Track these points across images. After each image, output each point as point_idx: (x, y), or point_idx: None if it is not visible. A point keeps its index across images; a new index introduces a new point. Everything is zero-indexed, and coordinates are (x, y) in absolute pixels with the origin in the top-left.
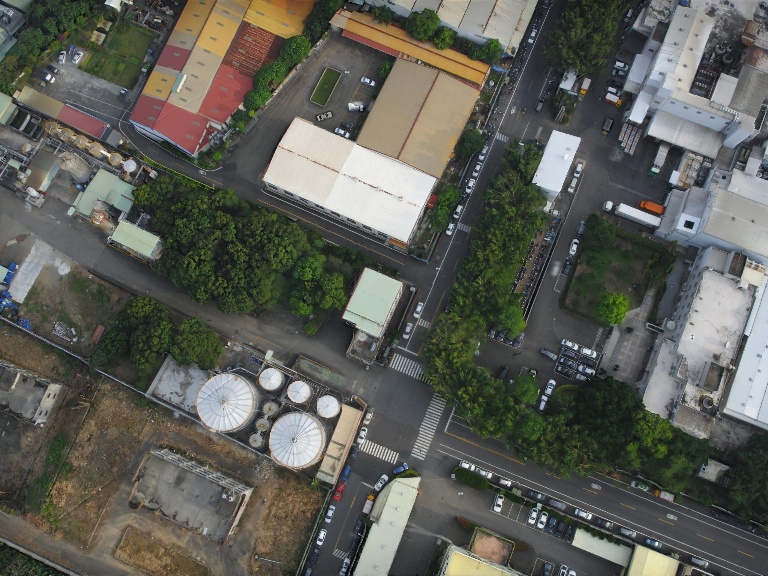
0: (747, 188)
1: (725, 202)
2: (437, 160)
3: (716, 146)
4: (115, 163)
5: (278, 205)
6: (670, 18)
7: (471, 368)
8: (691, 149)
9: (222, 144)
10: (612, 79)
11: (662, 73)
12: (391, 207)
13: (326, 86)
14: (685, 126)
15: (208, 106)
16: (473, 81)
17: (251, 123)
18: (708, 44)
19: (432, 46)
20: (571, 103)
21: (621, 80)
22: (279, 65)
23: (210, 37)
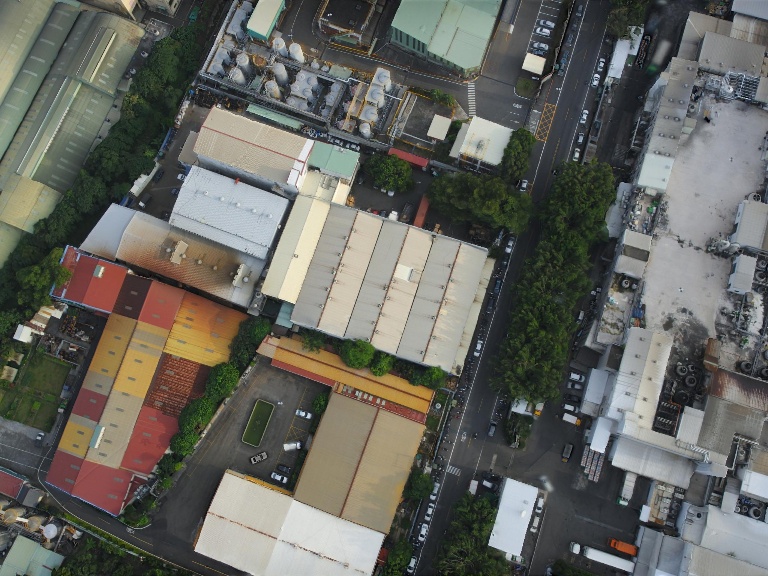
0: (725, 531)
1: (702, 563)
2: (384, 512)
3: (687, 475)
4: (34, 530)
5: (215, 567)
6: (624, 333)
7: None
8: (660, 479)
9: (150, 496)
10: (568, 392)
11: (620, 410)
12: (337, 575)
13: (258, 422)
14: (651, 454)
15: (131, 457)
16: (417, 410)
17: (179, 471)
18: (668, 361)
19: (370, 373)
20: (525, 430)
21: (578, 393)
22: (205, 407)
23: (128, 377)
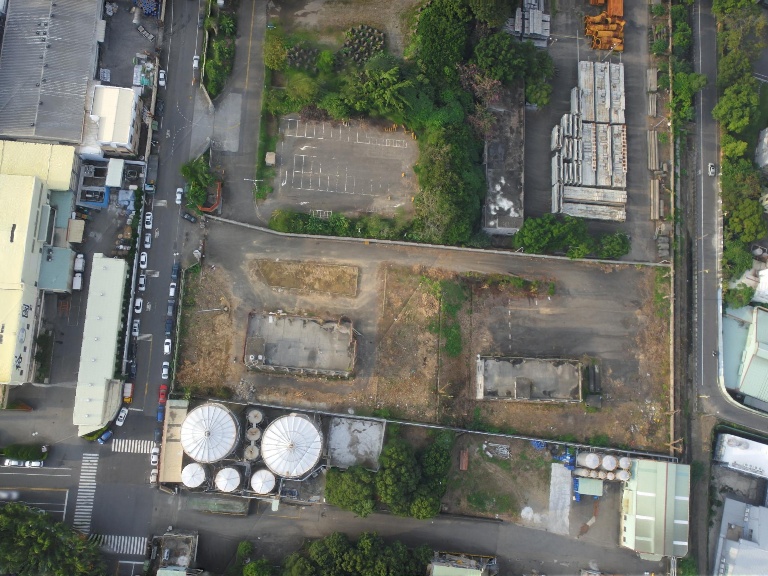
0: None
1: None
2: None
3: None
4: None
5: None
6: None
7: (43, 574)
8: None
9: None
10: None
11: None
12: None
13: None
14: None
15: None
16: None
17: None
18: None
19: None
20: None
21: None
22: None
23: None
